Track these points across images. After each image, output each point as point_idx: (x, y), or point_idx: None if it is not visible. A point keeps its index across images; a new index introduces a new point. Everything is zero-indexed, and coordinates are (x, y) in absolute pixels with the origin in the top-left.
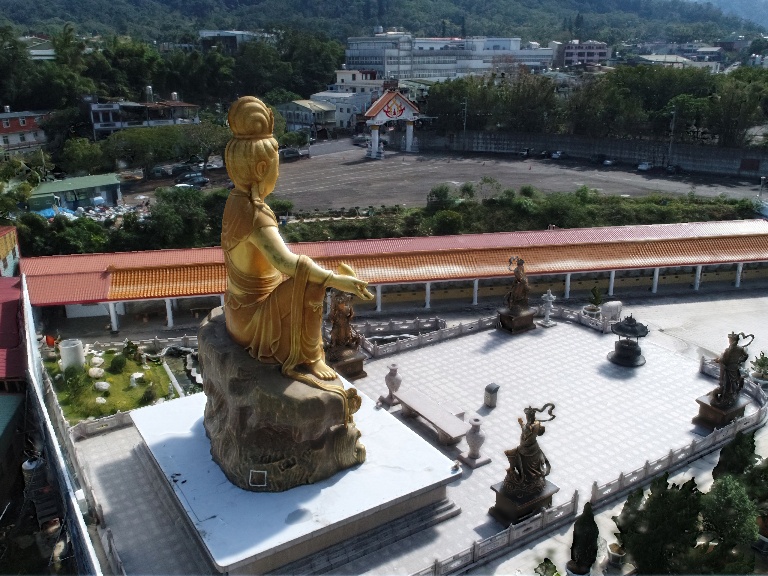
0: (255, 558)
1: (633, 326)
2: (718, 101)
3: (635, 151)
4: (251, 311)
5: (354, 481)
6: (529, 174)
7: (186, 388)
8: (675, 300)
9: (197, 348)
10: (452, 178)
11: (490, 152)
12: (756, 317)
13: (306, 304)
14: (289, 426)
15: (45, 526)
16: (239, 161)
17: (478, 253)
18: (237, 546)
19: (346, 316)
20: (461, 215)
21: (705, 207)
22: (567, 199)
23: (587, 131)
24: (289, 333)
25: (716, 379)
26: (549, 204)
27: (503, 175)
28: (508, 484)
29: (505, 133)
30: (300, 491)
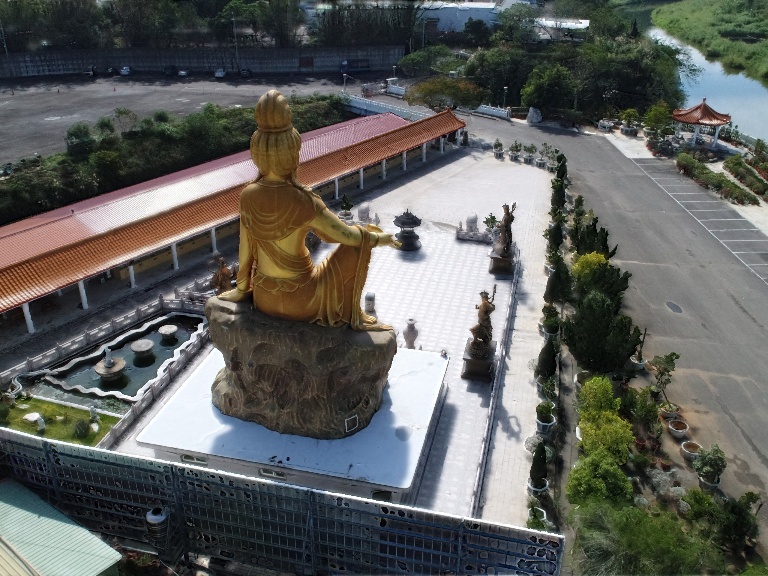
0: (415, 472)
1: (412, 218)
2: (267, 6)
3: (203, 59)
4: (311, 288)
5: (401, 394)
6: (122, 96)
7: (97, 406)
8: (382, 191)
9: (45, 367)
10: (45, 113)
11: (44, 76)
12: (438, 190)
13: (366, 266)
14: (379, 368)
15: (164, 573)
16: (285, 154)
17: (240, 189)
18: (397, 472)
19: (230, 278)
20: (116, 154)
21: (308, 106)
22: (207, 119)
23: (150, 43)
24: (351, 295)
25: (470, 241)
26: (188, 126)
27: (96, 101)
28: (478, 351)
29: (57, 52)
30: (378, 419)
